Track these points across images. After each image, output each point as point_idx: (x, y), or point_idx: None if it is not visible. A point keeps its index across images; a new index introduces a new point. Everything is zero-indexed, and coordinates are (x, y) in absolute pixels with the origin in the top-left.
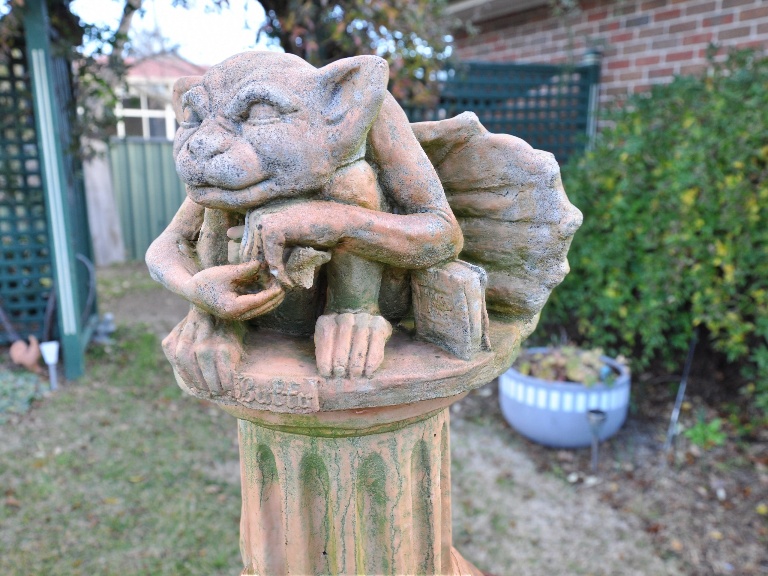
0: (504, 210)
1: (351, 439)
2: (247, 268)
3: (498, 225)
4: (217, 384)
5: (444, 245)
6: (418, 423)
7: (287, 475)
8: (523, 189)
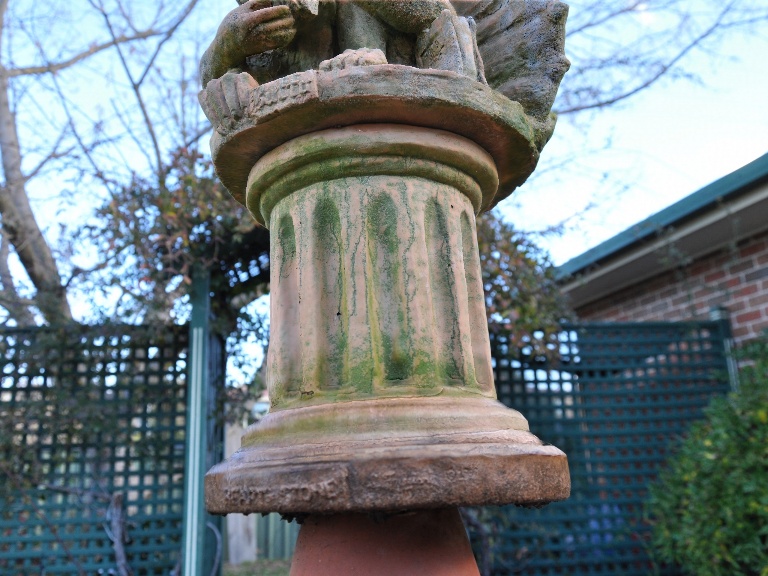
0: (500, 20)
1: (360, 179)
2: None
3: (498, 38)
4: (236, 103)
5: (434, 1)
6: (430, 182)
7: (302, 228)
8: None
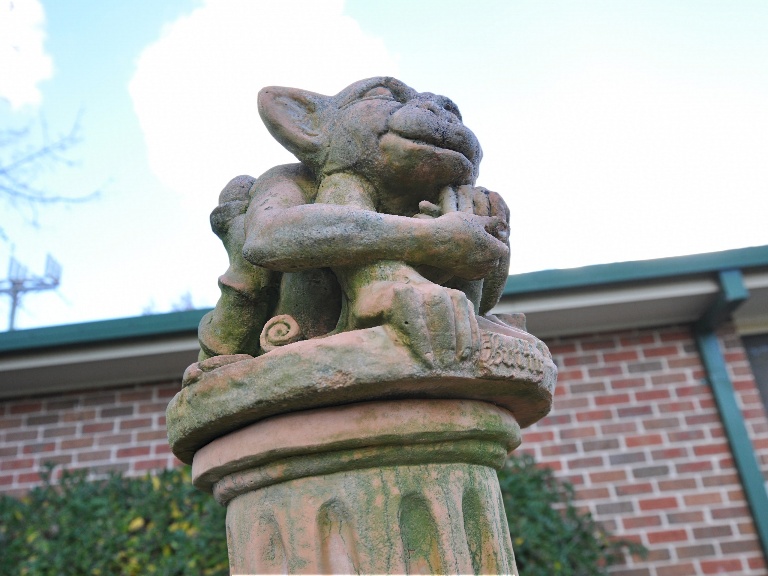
0: None
1: None
2: (495, 218)
3: None
4: None
5: None
6: None
7: (453, 525)
8: None
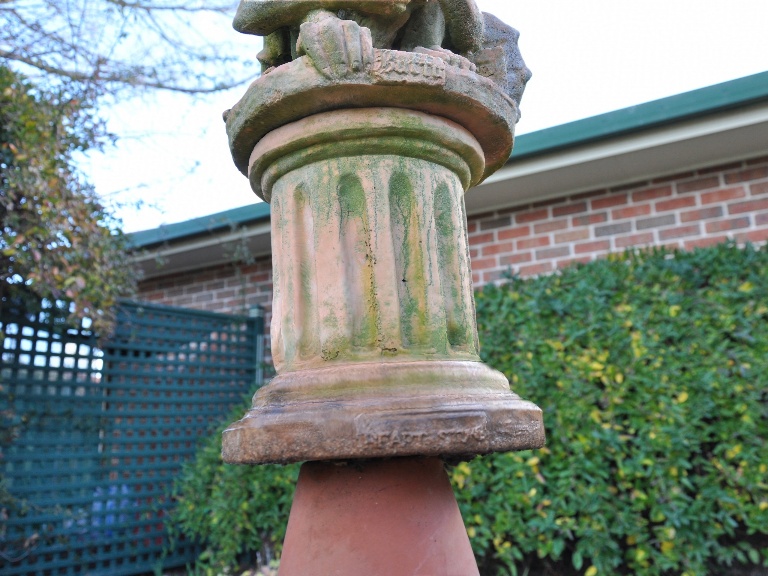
0: None
1: (430, 164)
2: None
3: None
4: (360, 55)
5: None
6: None
7: (377, 193)
8: (497, 44)
